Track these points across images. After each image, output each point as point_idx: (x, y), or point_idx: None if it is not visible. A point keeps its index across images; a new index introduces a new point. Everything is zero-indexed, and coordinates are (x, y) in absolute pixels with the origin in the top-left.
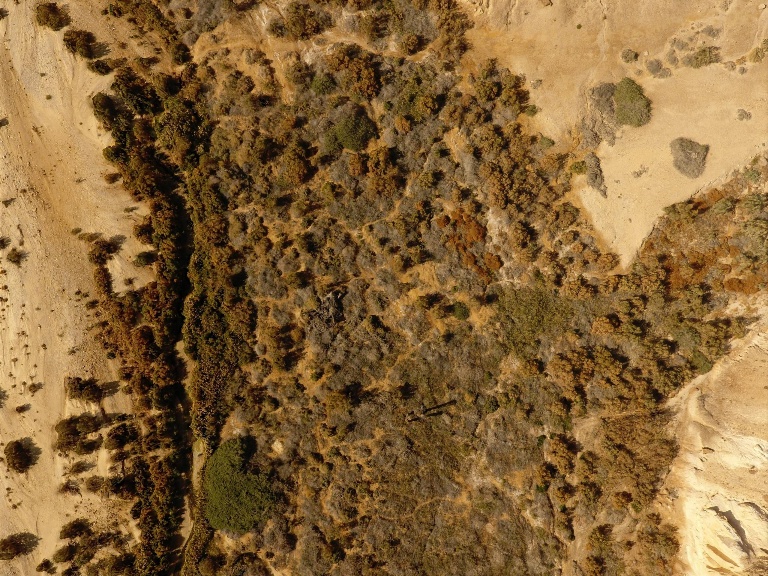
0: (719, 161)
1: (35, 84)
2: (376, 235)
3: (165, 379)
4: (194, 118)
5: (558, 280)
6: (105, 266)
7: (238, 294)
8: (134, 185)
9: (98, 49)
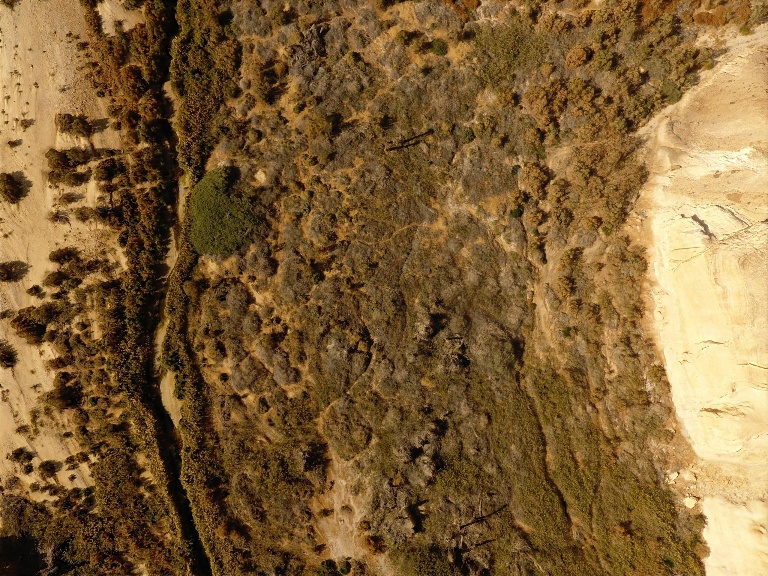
0: None
1: None
2: None
3: (152, 110)
4: None
5: (534, 18)
6: (96, 9)
7: (224, 32)
8: None
9: None
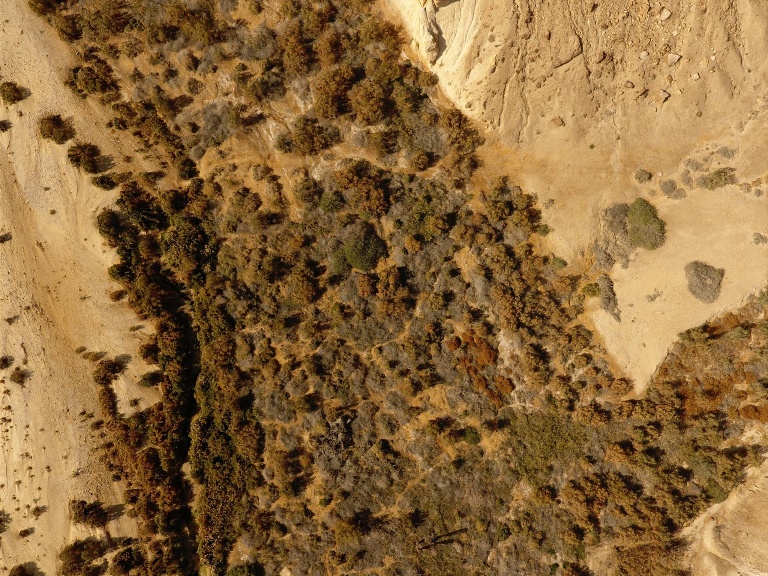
0: (734, 286)
1: (39, 198)
2: (386, 357)
3: (171, 505)
4: (201, 237)
5: (571, 404)
6: (110, 386)
7: (245, 417)
8: (140, 304)
9: (103, 163)
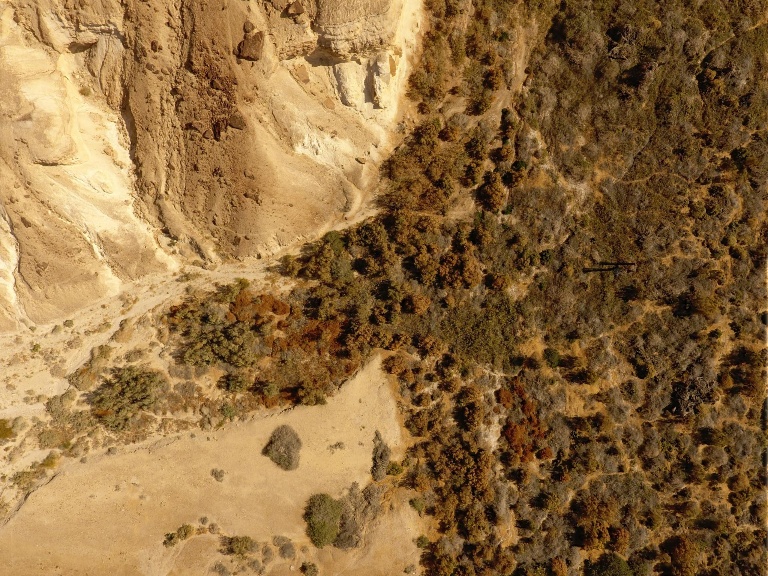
0: (256, 435)
1: None
2: (617, 460)
3: None
4: None
5: (446, 361)
6: None
7: None
8: None
9: None
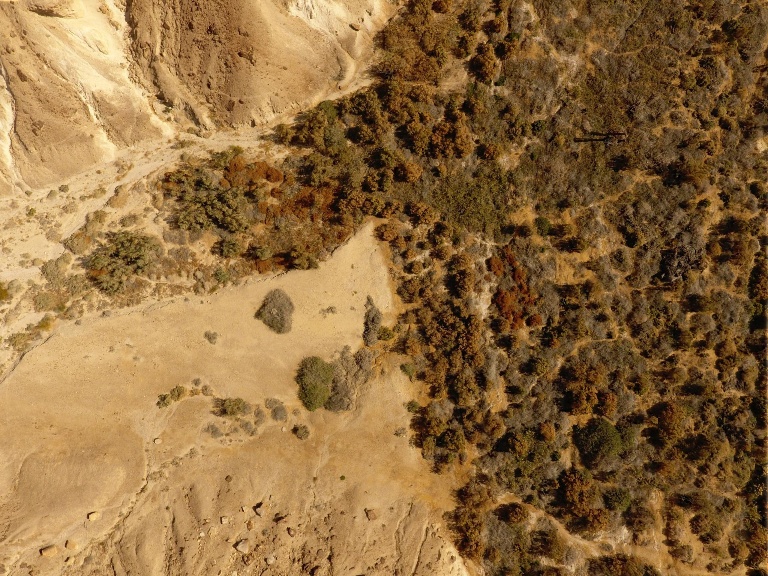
0: (250, 299)
1: None
2: (606, 327)
3: None
4: (765, 506)
5: (438, 229)
6: None
7: (763, 308)
8: None
9: None
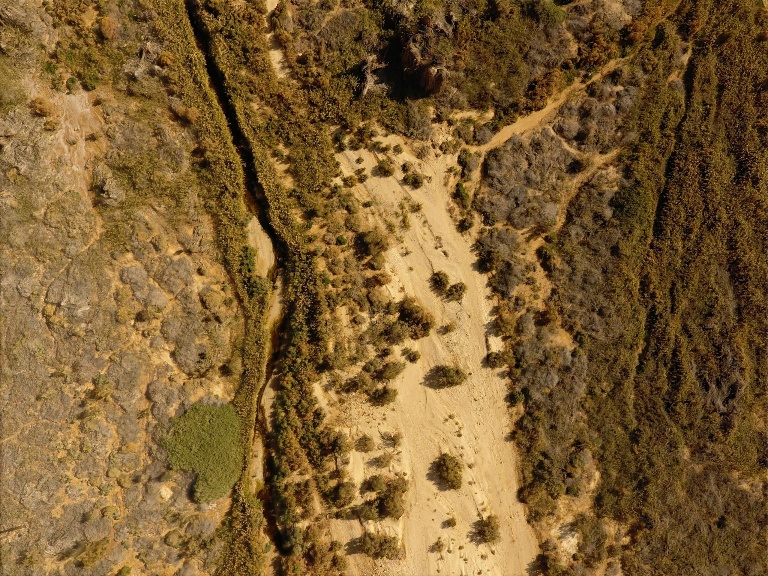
0: None
1: None
2: None
3: (287, 567)
4: None
5: None
6: None
7: None
8: None
9: None
